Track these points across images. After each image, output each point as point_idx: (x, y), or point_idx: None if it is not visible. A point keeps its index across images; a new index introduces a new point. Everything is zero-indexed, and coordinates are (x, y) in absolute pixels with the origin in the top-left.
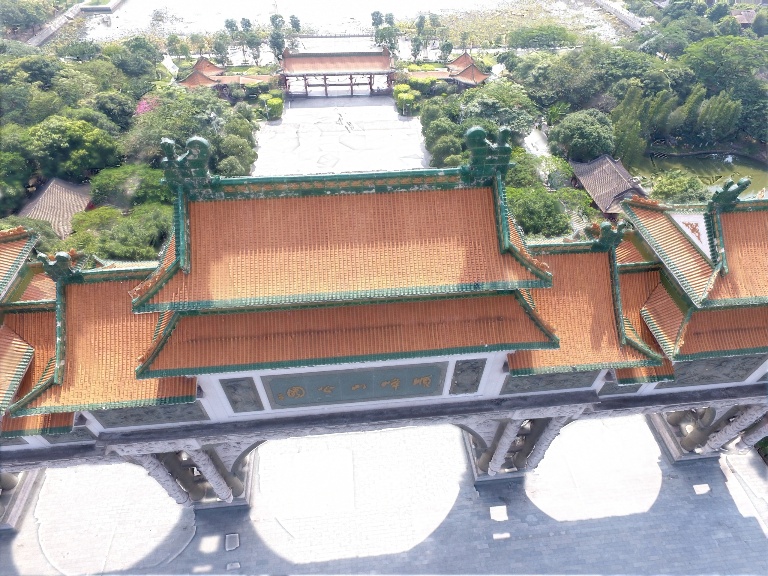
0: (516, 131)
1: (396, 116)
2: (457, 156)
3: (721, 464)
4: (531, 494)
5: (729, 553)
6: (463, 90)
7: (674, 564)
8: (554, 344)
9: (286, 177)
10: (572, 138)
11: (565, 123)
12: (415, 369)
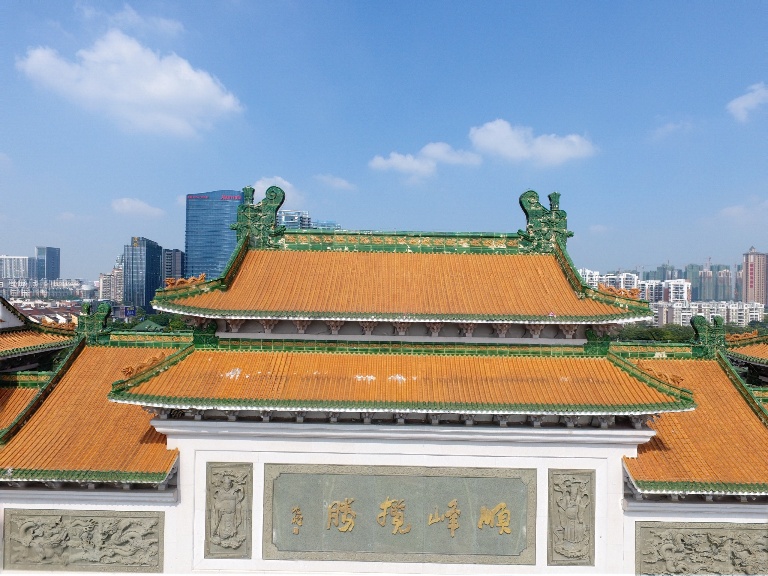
0: None
1: None
2: None
3: None
4: None
5: None
6: None
7: None
8: None
9: (456, 232)
10: None
11: None
12: None
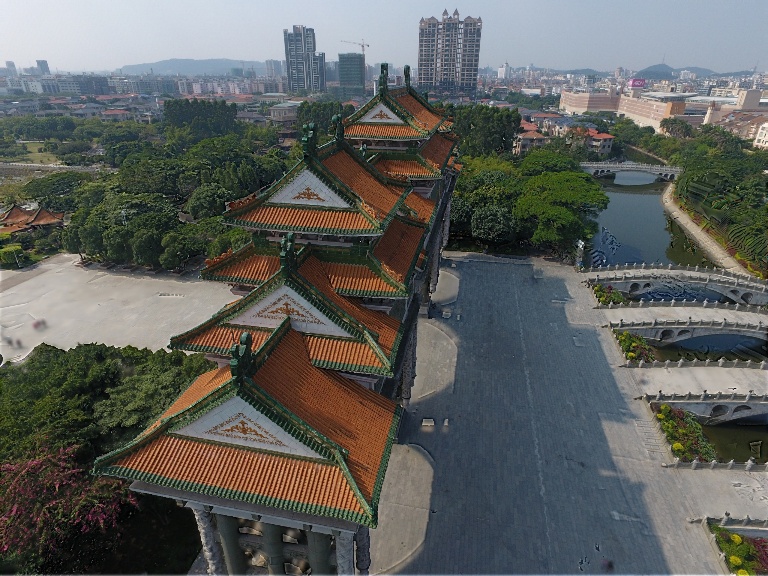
0: (172, 215)
1: (13, 272)
2: (173, 233)
3: (444, 258)
4: (440, 304)
5: (482, 269)
6: (54, 229)
7: (483, 281)
8: (456, 142)
9: None
10: (215, 201)
11: (199, 196)
12: (438, 181)
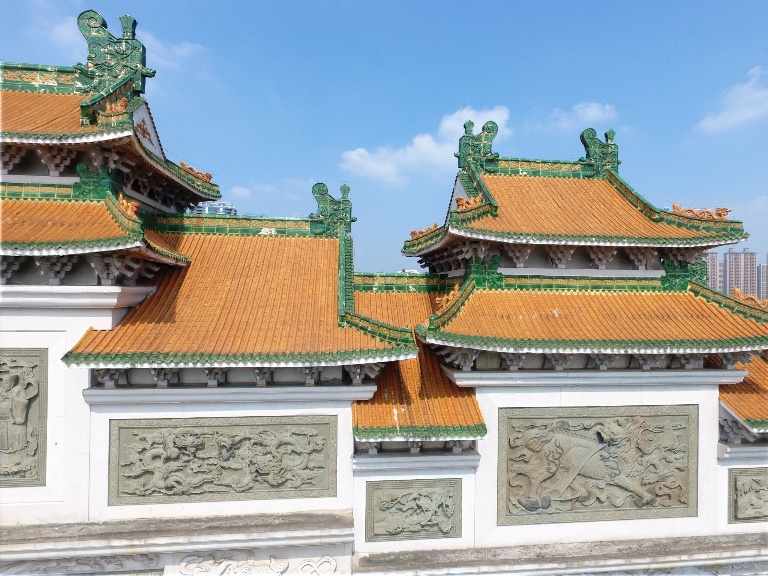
0: None
1: None
2: None
3: None
4: None
5: None
6: None
7: None
8: None
9: None
10: None
11: None
12: None
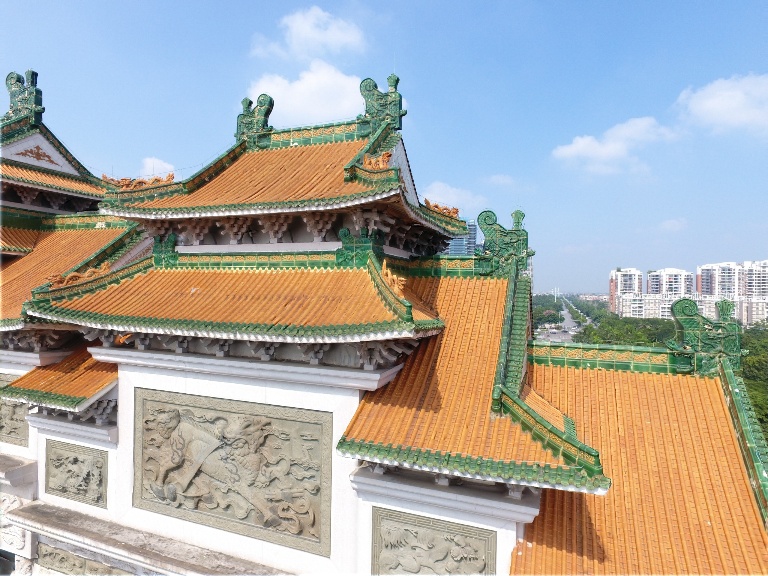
0: None
1: None
2: None
3: None
4: None
5: None
6: None
7: None
8: None
9: None
10: None
11: None
12: None
